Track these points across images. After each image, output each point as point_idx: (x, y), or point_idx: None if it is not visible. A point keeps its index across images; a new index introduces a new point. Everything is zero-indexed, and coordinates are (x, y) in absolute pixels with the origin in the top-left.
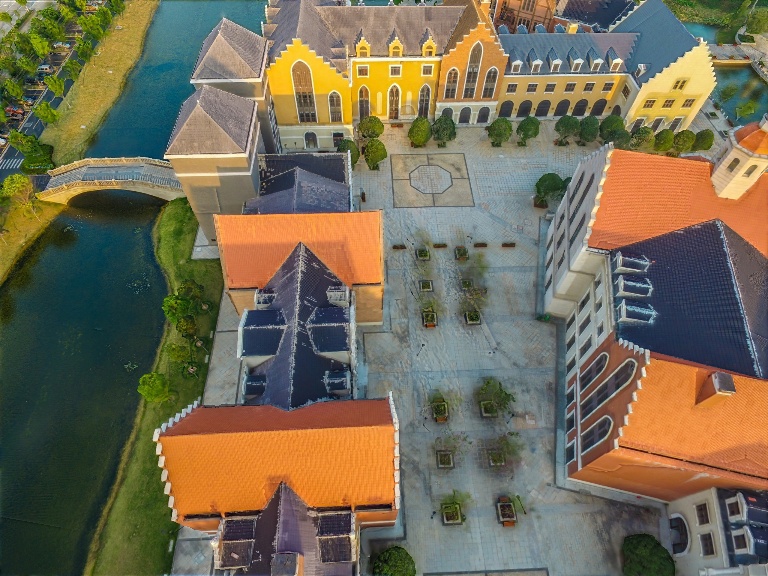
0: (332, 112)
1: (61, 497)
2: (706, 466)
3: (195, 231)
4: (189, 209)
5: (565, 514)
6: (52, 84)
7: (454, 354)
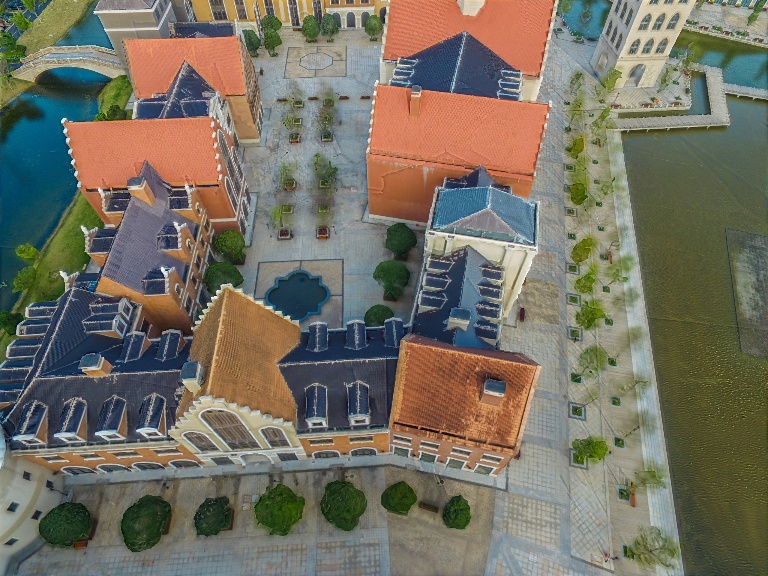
0: (238, 10)
1: (19, 235)
2: (424, 161)
3: (130, 94)
4: (127, 81)
5: (364, 234)
6: (26, 0)
7: (308, 157)
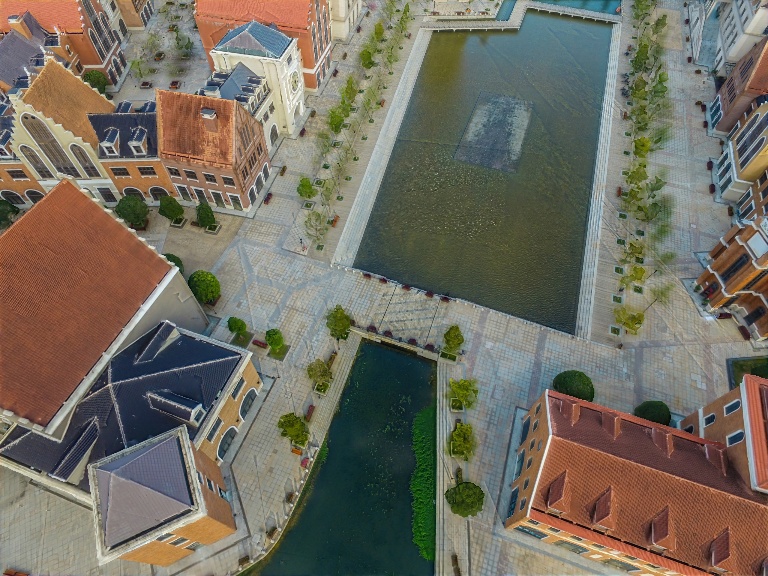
0: None
1: None
2: (234, 20)
3: None
4: None
5: None
6: None
7: None
